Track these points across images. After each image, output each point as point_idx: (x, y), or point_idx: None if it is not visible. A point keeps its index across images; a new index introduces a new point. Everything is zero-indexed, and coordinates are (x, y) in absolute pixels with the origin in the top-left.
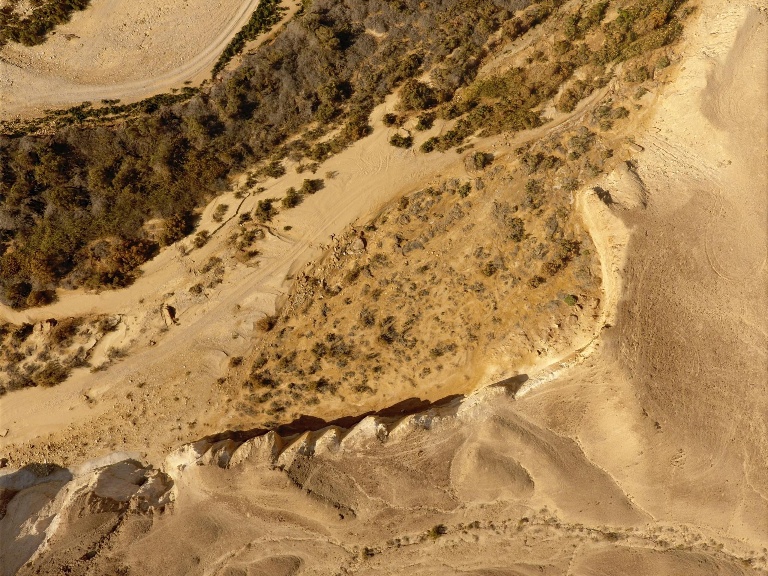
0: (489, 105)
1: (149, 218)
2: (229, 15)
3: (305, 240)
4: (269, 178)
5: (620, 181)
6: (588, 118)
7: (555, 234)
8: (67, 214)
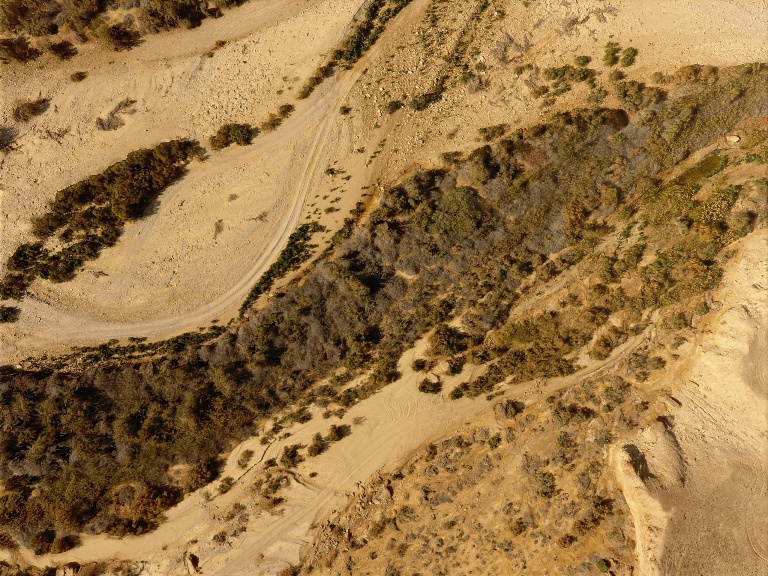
0: (521, 350)
1: (174, 463)
2: (258, 252)
3: (331, 487)
4: (295, 423)
5: (656, 445)
6: (623, 367)
7: (587, 491)
8: (92, 461)
